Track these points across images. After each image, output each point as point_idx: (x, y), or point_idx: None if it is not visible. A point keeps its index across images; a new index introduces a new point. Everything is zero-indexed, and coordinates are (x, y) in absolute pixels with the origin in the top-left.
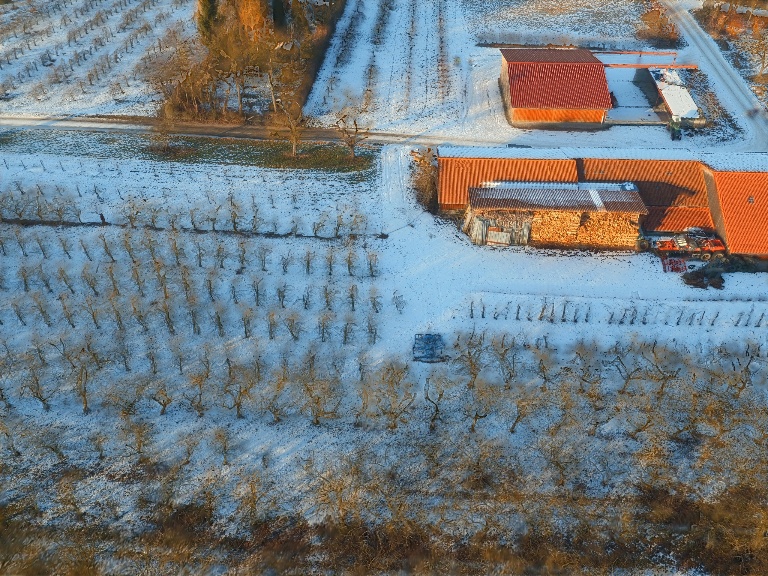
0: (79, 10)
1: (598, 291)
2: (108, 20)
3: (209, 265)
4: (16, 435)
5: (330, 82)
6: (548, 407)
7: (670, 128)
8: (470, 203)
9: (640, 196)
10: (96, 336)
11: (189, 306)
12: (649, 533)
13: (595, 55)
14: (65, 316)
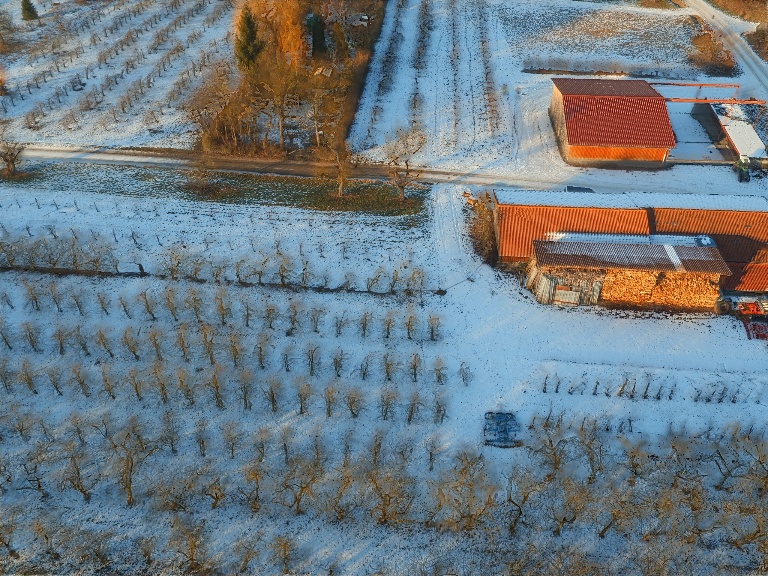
0: (109, 28)
1: (678, 361)
2: (138, 39)
3: (256, 325)
4: (55, 532)
5: (374, 113)
6: (639, 505)
7: (737, 169)
8: (537, 259)
9: (718, 252)
10: (138, 409)
11: (237, 374)
12: None
13: (652, 86)
14: (106, 389)
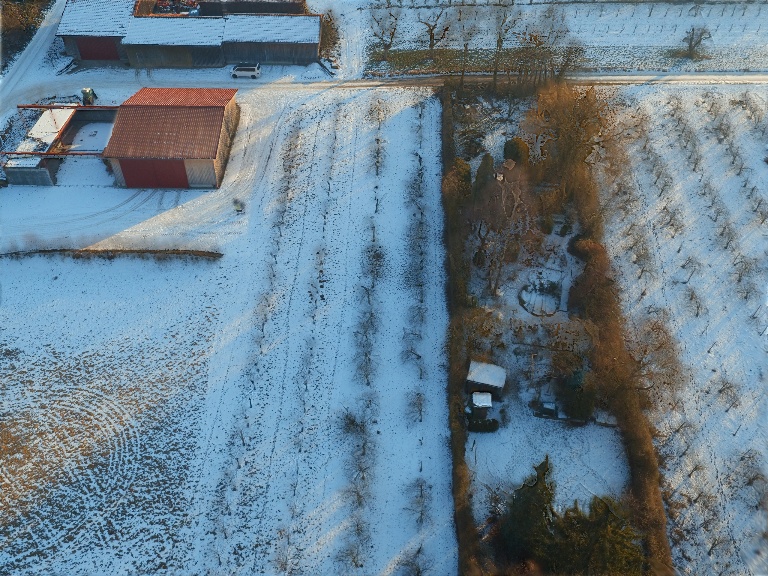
0: None
1: None
2: None
3: None
4: None
5: None
6: None
7: None
8: None
9: None
10: None
11: None
12: None
13: None
14: None
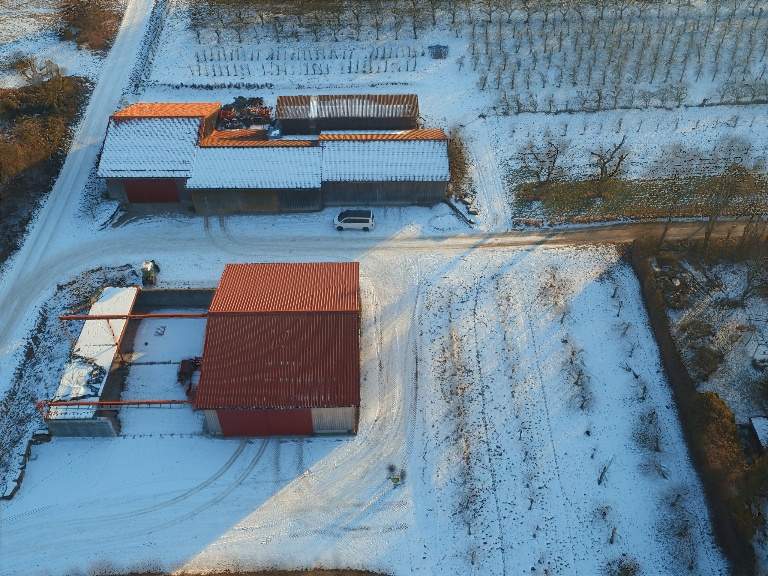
0: None
1: (326, 94)
2: None
3: (598, 85)
4: None
5: None
6: None
7: None
8: None
9: None
10: None
11: None
12: (345, 3)
13: None
14: None
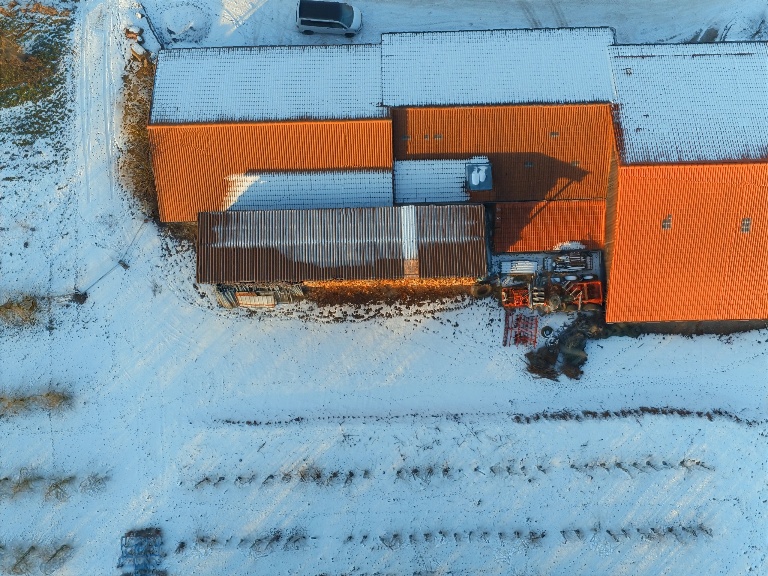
0: None
1: (397, 397)
2: None
3: None
4: None
5: None
6: None
7: None
8: (196, 267)
9: None
10: None
11: None
12: None
13: None
14: None
